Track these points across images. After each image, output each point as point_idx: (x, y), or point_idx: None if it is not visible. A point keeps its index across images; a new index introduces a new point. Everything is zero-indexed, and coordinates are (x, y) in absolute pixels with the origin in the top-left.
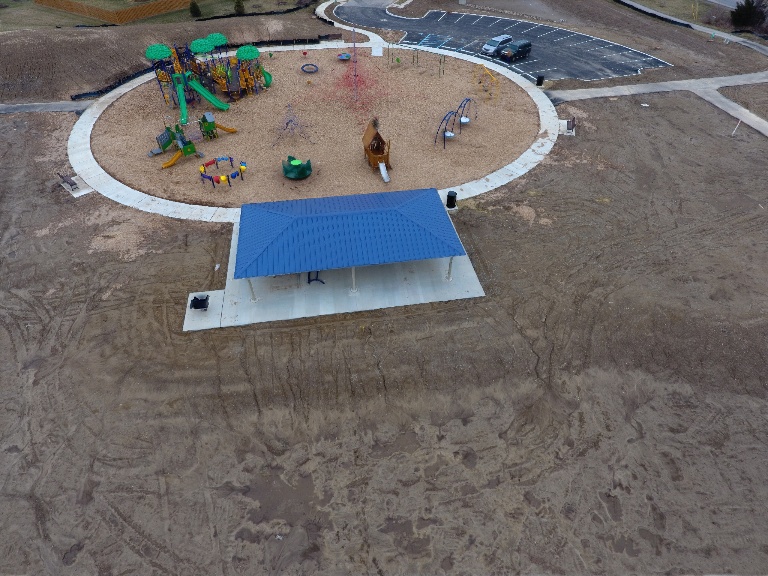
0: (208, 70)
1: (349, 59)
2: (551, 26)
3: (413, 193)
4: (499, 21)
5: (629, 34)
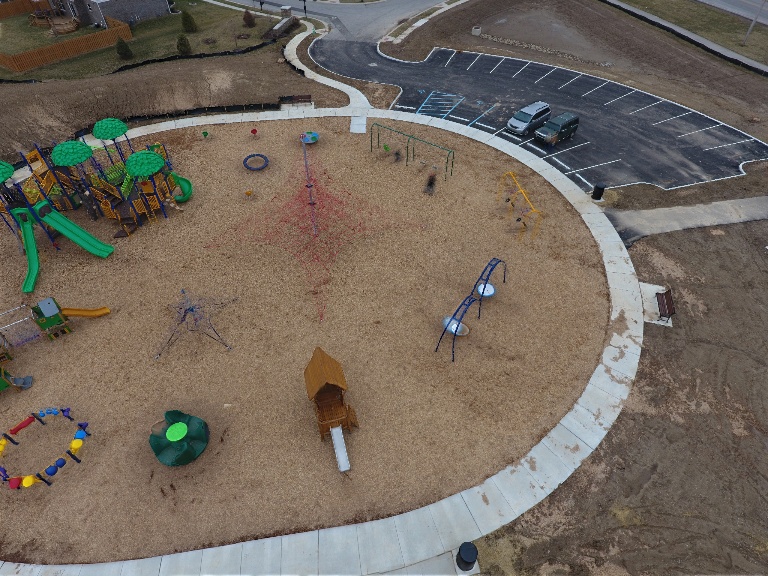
0: (85, 186)
1: (316, 141)
2: (597, 77)
3: None
4: (526, 67)
5: (706, 91)
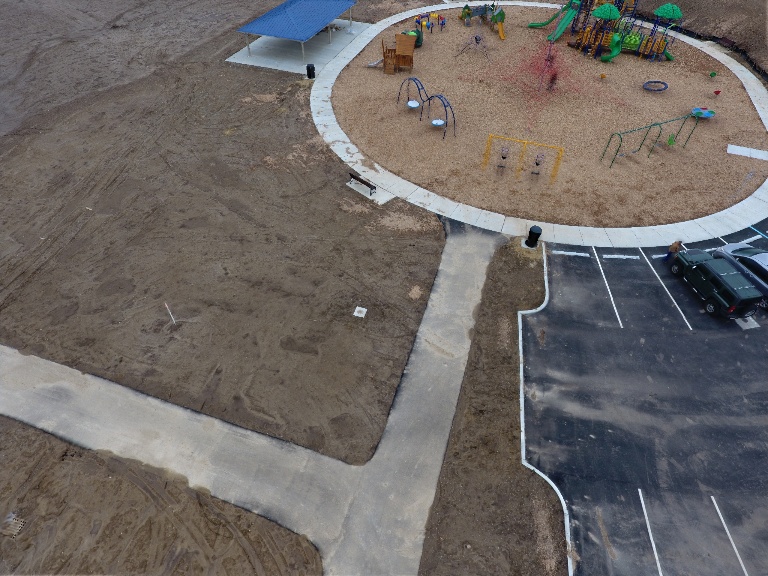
0: None
1: (700, 119)
2: None
3: (306, 31)
4: None
5: None
